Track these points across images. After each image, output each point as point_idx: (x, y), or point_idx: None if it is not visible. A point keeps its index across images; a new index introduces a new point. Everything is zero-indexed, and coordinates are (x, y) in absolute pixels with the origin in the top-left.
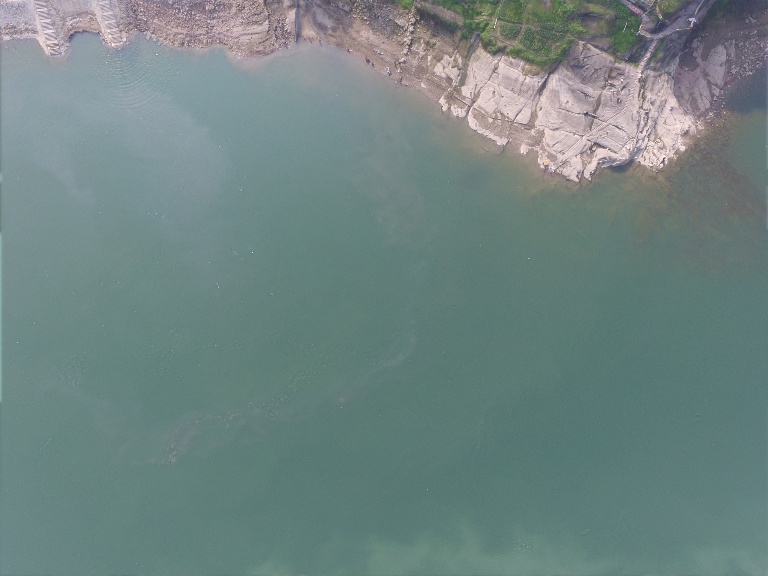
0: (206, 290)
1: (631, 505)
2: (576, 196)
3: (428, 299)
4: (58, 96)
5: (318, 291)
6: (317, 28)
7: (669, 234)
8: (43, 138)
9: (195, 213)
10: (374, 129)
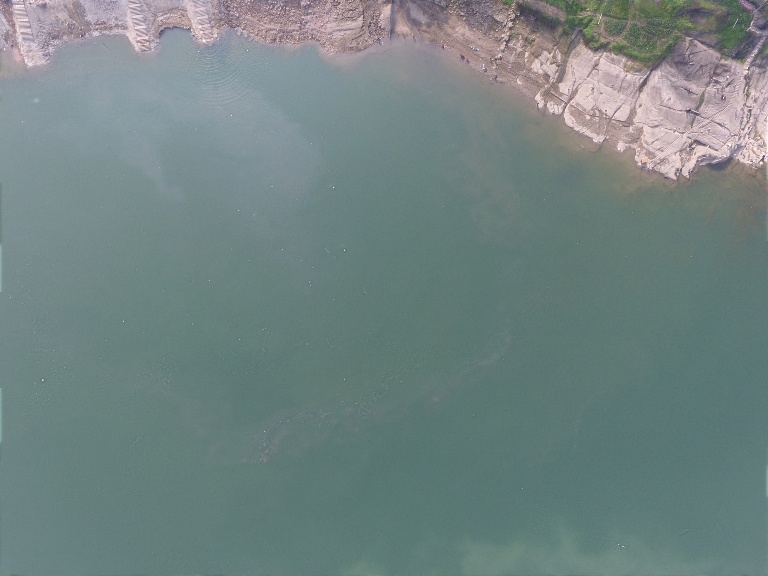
0: (298, 288)
1: (725, 505)
2: (673, 194)
3: (523, 298)
4: (147, 93)
5: (411, 289)
6: (411, 24)
7: (767, 232)
8: (132, 135)
9: (287, 211)
10: (468, 126)
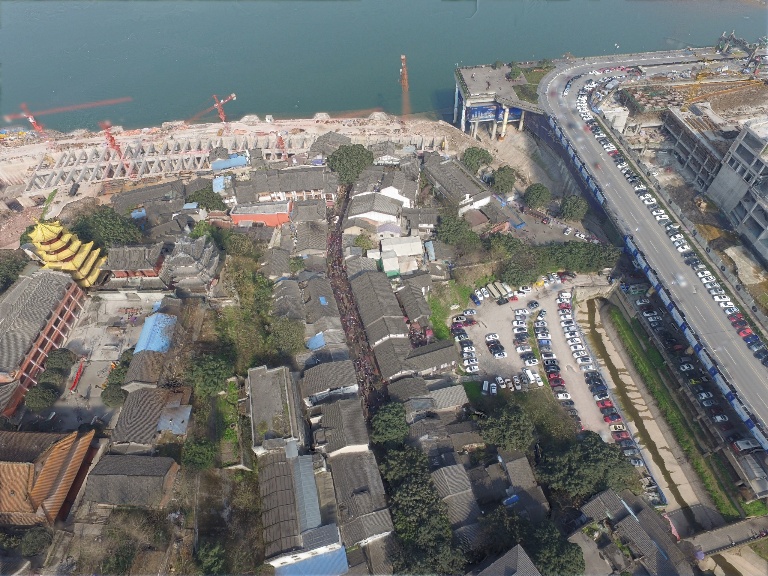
0: None
1: None
2: None
3: None
4: None
5: (42, 70)
6: None
7: None
8: None
9: None
10: None
